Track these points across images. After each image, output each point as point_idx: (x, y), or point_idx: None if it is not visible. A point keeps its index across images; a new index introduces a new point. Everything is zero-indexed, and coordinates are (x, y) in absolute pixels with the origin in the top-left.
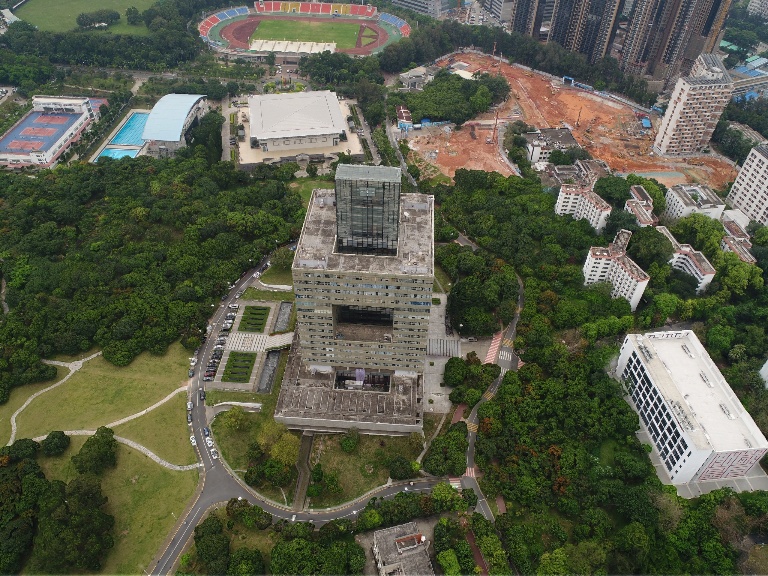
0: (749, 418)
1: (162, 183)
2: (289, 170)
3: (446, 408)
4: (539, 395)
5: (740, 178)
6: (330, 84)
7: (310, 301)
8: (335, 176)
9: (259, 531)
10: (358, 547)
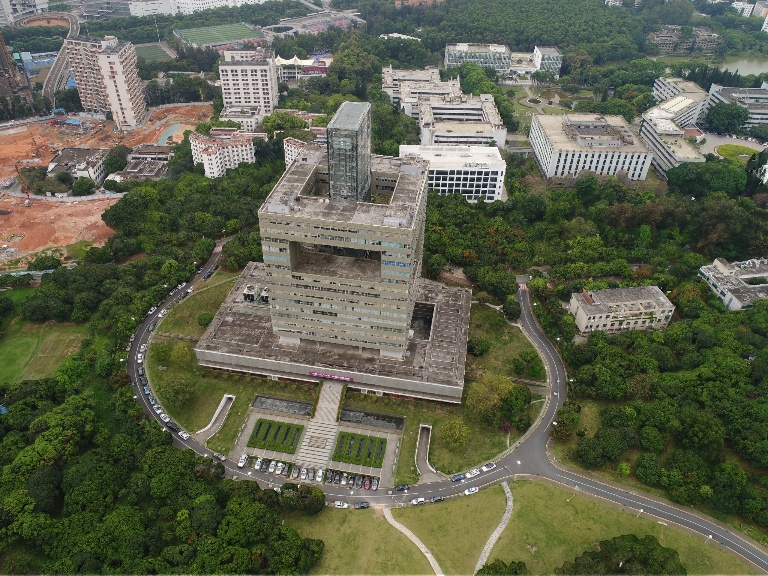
0: (476, 147)
1: None
2: None
3: None
4: None
5: (226, 94)
6: None
7: None
8: (352, 129)
9: None
10: (595, 331)
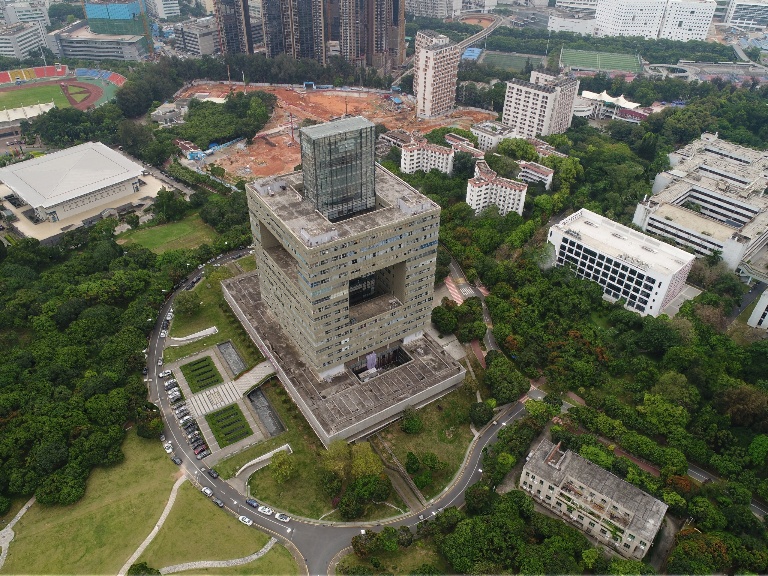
0: (668, 245)
1: None
2: (108, 226)
3: (461, 352)
4: (525, 302)
5: (506, 110)
6: (77, 141)
7: (326, 286)
8: (311, 137)
9: (403, 551)
10: (518, 491)
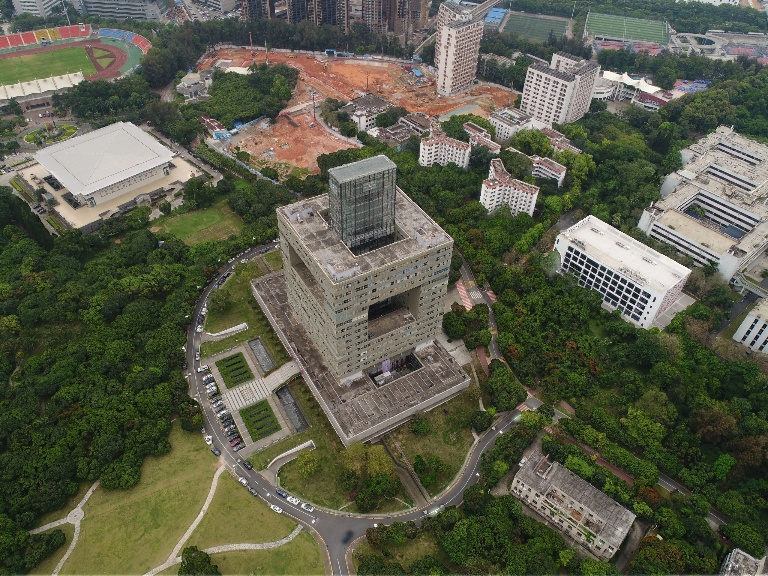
0: (667, 258)
1: (6, 281)
2: (143, 215)
3: (467, 357)
4: (529, 311)
5: (525, 94)
6: (107, 116)
7: (349, 312)
8: (338, 181)
9: (409, 542)
10: (509, 496)
